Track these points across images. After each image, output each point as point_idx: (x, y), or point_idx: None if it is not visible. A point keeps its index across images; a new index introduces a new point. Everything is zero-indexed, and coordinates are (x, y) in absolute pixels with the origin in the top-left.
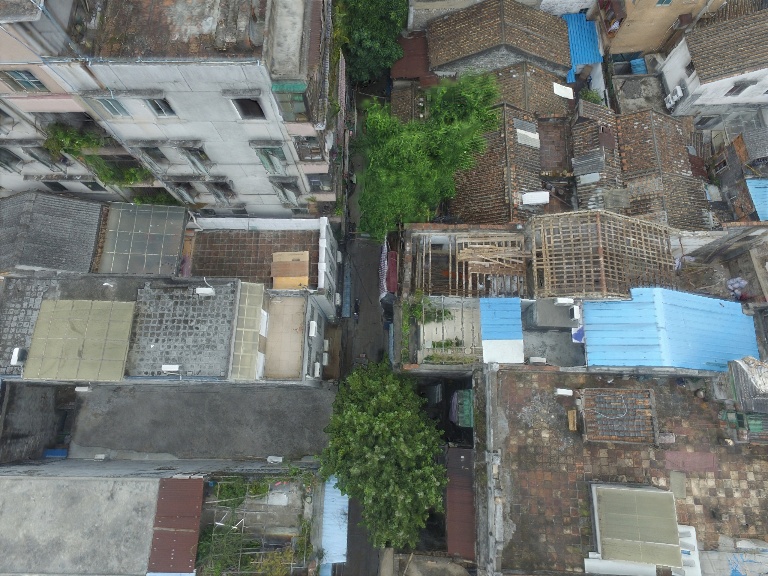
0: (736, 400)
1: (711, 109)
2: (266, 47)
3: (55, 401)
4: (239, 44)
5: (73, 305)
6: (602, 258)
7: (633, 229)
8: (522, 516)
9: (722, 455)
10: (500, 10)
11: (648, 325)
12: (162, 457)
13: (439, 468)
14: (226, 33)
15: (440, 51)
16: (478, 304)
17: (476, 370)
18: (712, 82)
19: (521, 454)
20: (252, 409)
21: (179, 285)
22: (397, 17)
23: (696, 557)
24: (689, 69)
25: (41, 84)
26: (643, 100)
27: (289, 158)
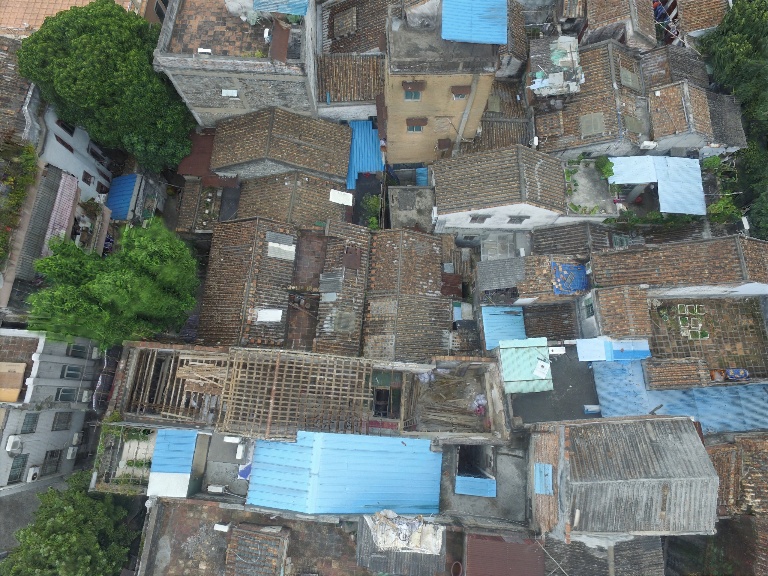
0: None
1: (467, 230)
2: None
3: None
4: None
5: None
6: (272, 400)
7: (324, 366)
8: None
9: None
10: (269, 122)
11: (303, 470)
12: None
13: None
14: None
15: (219, 154)
16: (155, 435)
17: None
18: (446, 214)
19: None
20: None
21: None
22: (167, 124)
23: None
24: None
25: None
26: (415, 212)
27: None
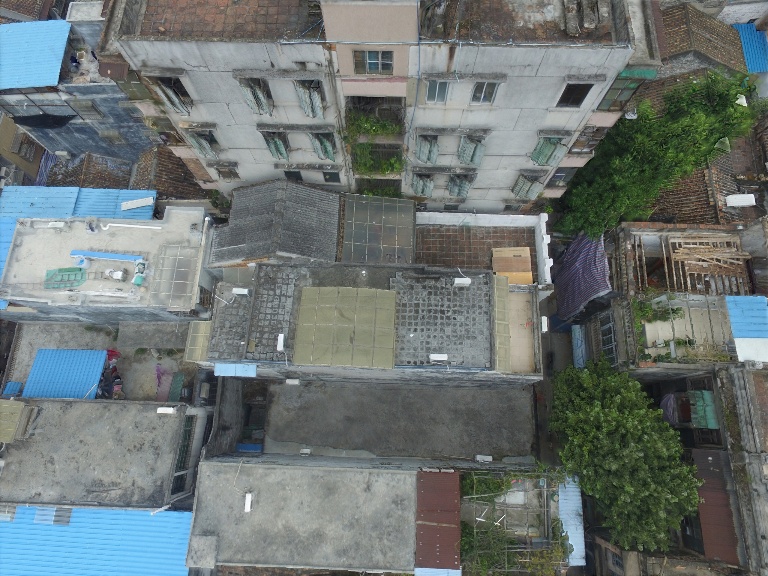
0: None
1: None
2: (633, 32)
3: (242, 395)
4: (598, 29)
5: (339, 292)
6: None
7: None
8: None
9: None
10: (686, 17)
11: None
12: (359, 454)
13: (692, 469)
14: (584, 19)
15: None
16: (724, 302)
17: (721, 369)
18: None
19: None
20: (447, 408)
21: (430, 275)
22: None
23: None
24: None
25: (388, 66)
26: None
27: None
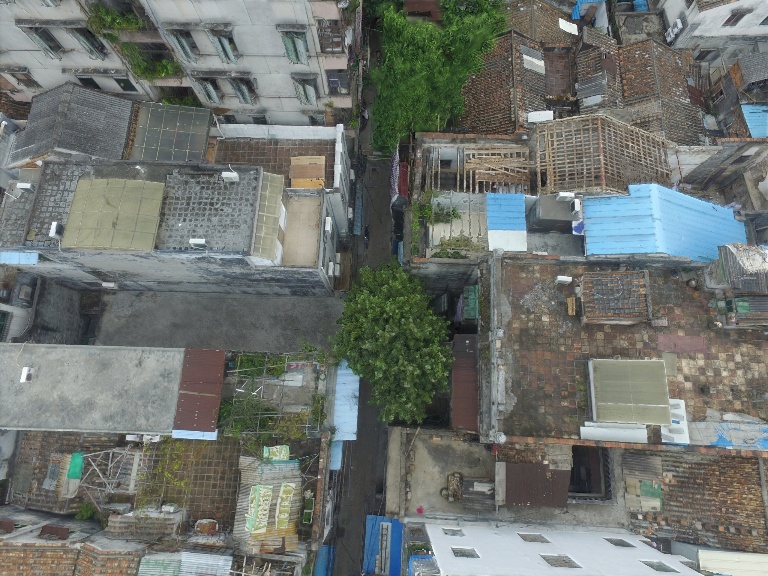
0: (725, 280)
1: (709, 41)
2: None
3: (80, 306)
4: None
5: (108, 183)
6: (602, 156)
7: (632, 136)
8: (523, 390)
9: (711, 339)
10: None
11: (644, 217)
12: None
13: (445, 349)
14: None
15: None
16: (485, 199)
17: (482, 261)
18: (710, 9)
19: (523, 336)
20: (267, 314)
21: (205, 172)
22: None
23: (685, 425)
24: (689, 1)
25: None
26: (645, 36)
27: (311, 49)
